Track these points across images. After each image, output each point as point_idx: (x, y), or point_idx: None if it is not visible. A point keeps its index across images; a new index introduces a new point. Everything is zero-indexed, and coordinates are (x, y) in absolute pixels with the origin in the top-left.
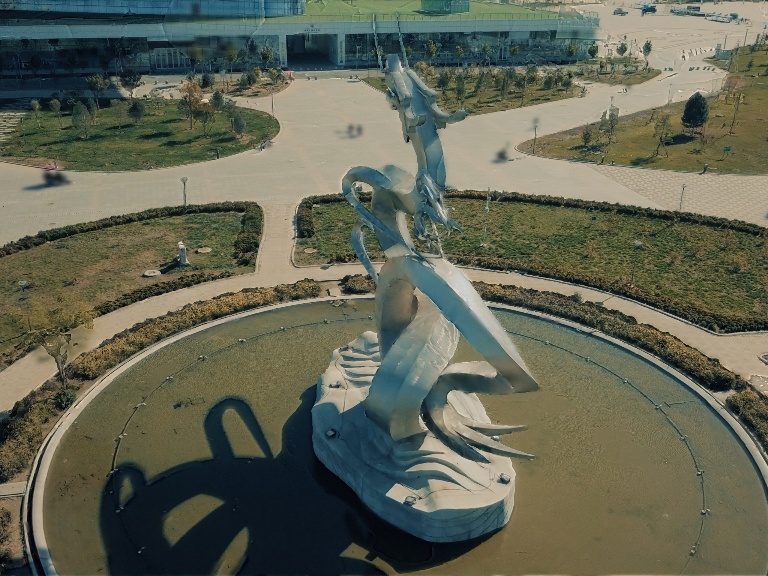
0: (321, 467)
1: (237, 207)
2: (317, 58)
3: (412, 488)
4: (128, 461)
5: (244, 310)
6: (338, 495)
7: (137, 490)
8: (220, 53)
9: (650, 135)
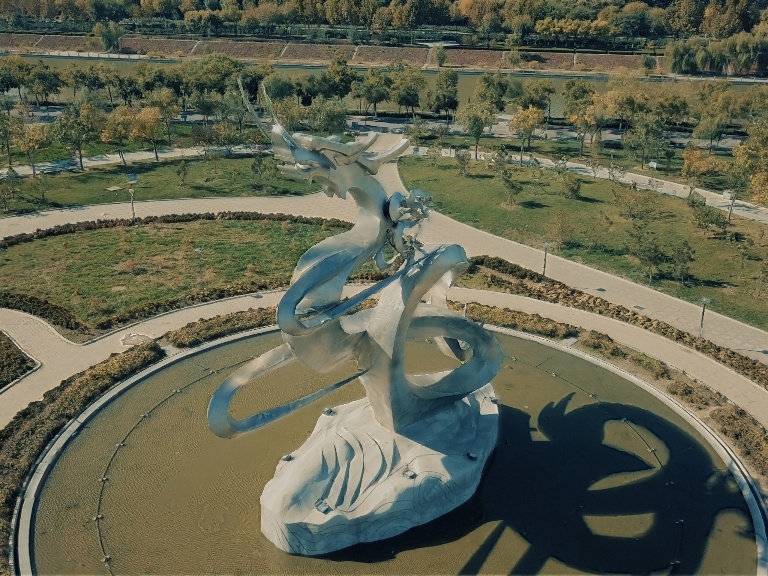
0: None
1: None
2: None
3: None
4: None
5: None
6: None
7: (645, 575)
8: None
9: None
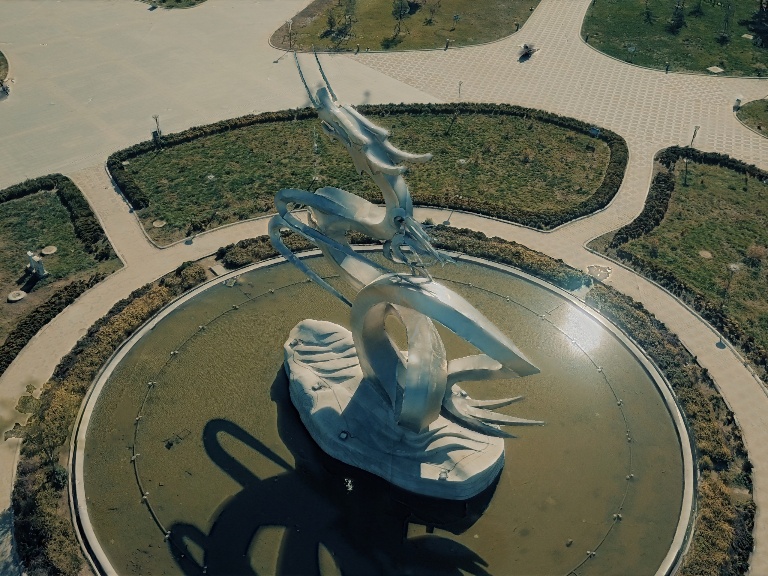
0: (336, 463)
1: (44, 184)
2: None
3: (437, 464)
4: (171, 519)
5: (150, 317)
6: (357, 480)
7: (202, 544)
8: None
9: (380, 6)
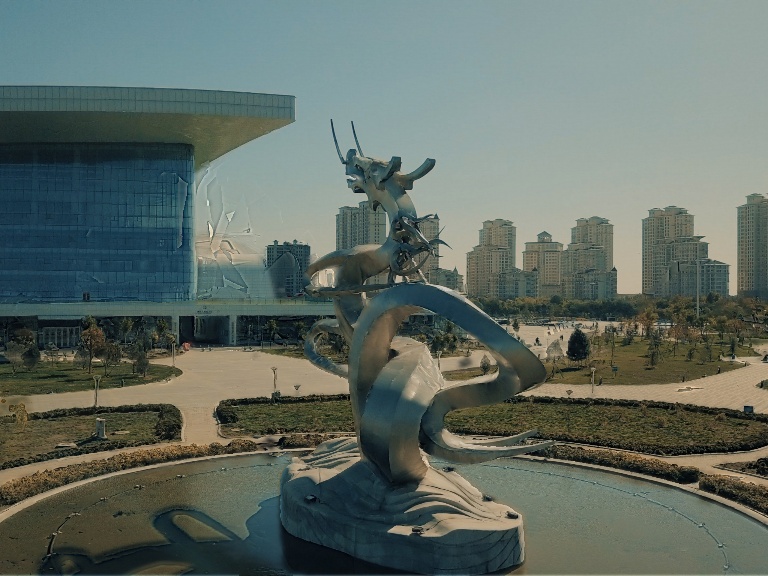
0: (299, 544)
1: (151, 408)
2: (207, 342)
3: (415, 525)
4: (67, 550)
5: (178, 460)
6: (321, 573)
7: (83, 567)
8: (135, 276)
9: None
